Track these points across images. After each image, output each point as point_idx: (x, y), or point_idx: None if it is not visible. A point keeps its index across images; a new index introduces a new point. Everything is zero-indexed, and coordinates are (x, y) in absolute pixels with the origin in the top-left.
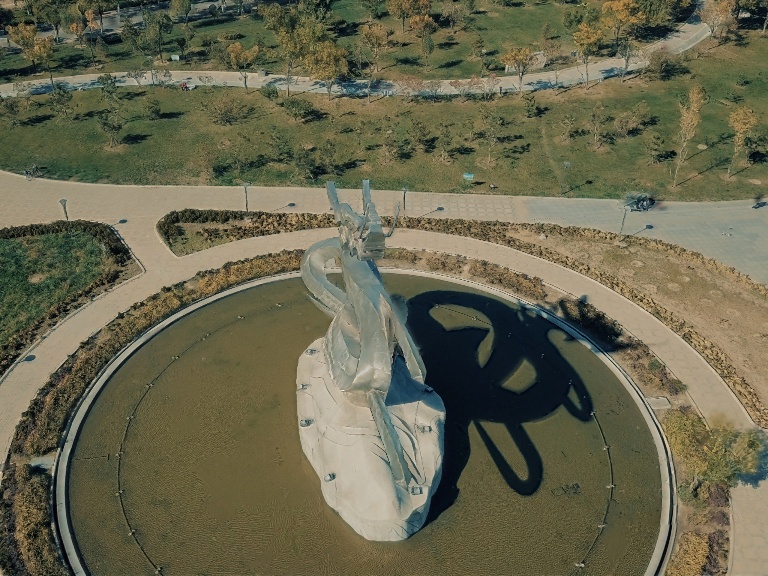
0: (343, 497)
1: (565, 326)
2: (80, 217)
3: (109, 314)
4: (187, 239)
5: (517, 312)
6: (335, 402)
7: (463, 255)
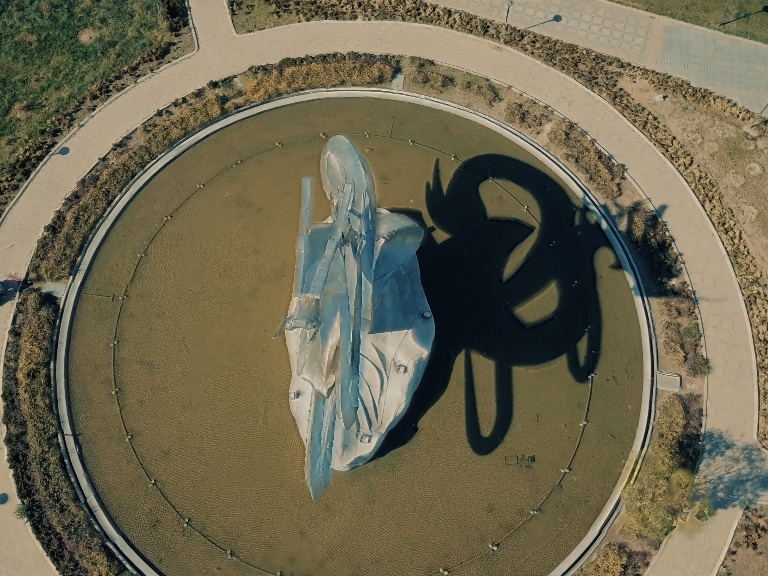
0: (300, 420)
1: (619, 248)
2: None
3: (149, 107)
4: (253, 7)
5: (576, 211)
6: None
7: (552, 106)
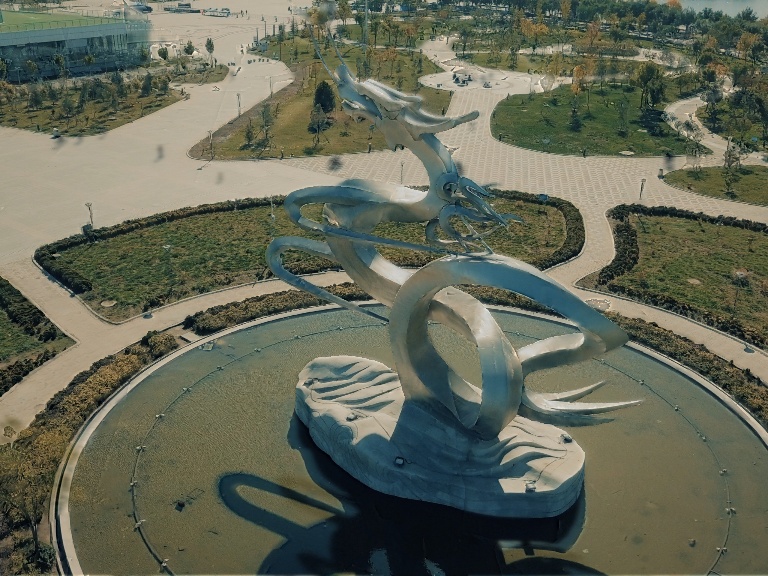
0: None
1: None
2: None
3: None
4: None
5: None
6: None
7: None
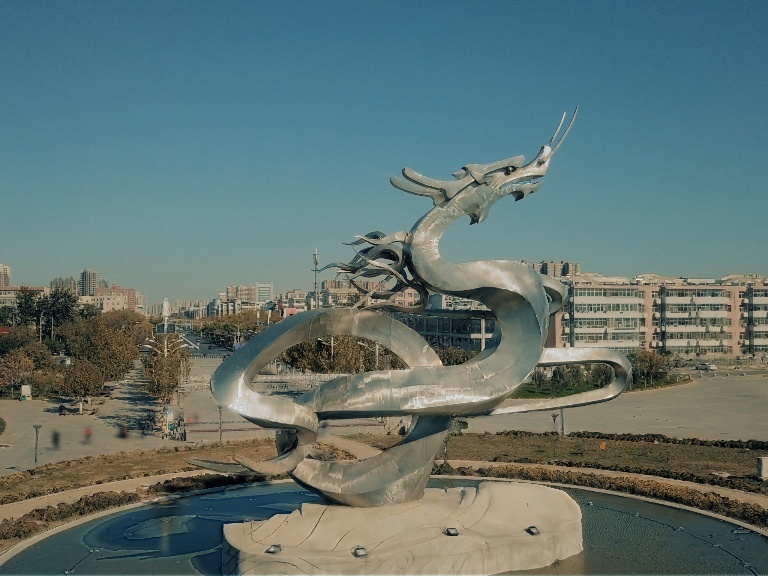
0: (556, 528)
1: (202, 490)
2: None
3: None
4: None
5: (161, 507)
6: (419, 506)
7: None
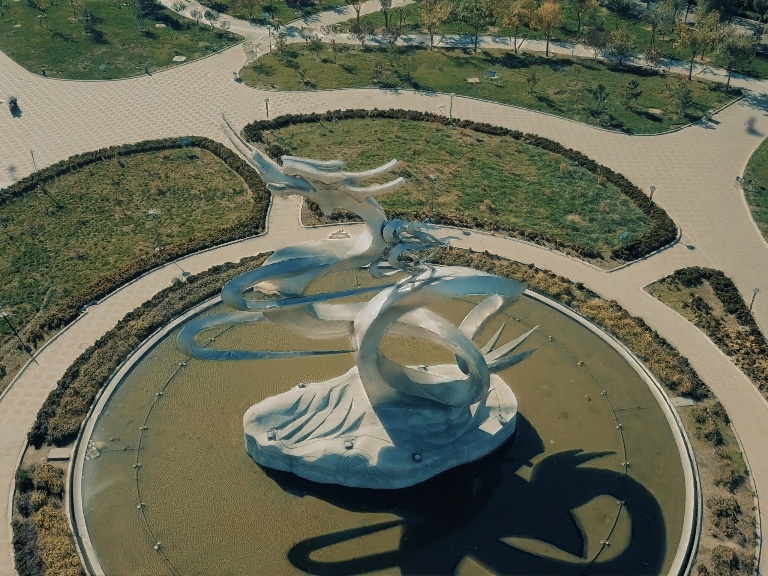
0: None
1: None
2: (684, 222)
3: (534, 261)
4: (679, 290)
5: None
6: None
7: (763, 542)
